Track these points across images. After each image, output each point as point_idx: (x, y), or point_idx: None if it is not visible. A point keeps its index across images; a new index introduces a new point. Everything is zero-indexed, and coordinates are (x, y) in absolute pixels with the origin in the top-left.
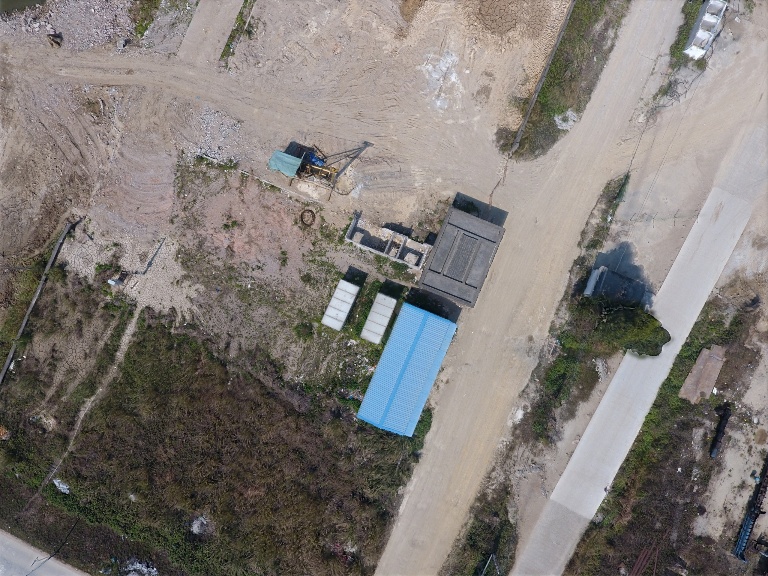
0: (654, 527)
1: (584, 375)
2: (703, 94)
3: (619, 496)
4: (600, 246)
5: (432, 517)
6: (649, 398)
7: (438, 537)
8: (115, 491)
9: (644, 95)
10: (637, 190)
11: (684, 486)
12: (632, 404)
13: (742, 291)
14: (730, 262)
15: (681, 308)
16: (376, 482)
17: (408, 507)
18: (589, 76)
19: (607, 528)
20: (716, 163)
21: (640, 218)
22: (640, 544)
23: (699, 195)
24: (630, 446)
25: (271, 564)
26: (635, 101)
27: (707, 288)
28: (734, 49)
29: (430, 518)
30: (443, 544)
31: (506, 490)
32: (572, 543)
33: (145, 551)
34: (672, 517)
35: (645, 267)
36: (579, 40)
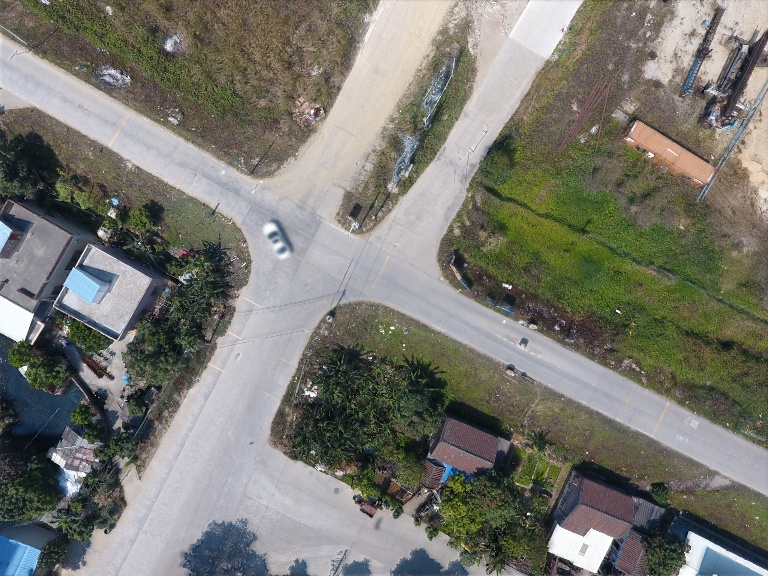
0: (607, 67)
1: None
2: None
3: (575, 36)
4: None
5: (396, 47)
6: None
7: (401, 66)
8: (93, 3)
9: None
10: None
11: (638, 31)
12: None
13: None
14: None
15: None
16: (343, 1)
17: (373, 36)
18: None
19: (562, 69)
20: None
21: None
22: (593, 80)
23: None
24: None
25: (240, 75)
26: None
27: None
28: None
29: (394, 47)
30: (405, 73)
31: (468, 25)
32: (528, 80)
33: (120, 63)
34: (625, 57)
35: None
36: None
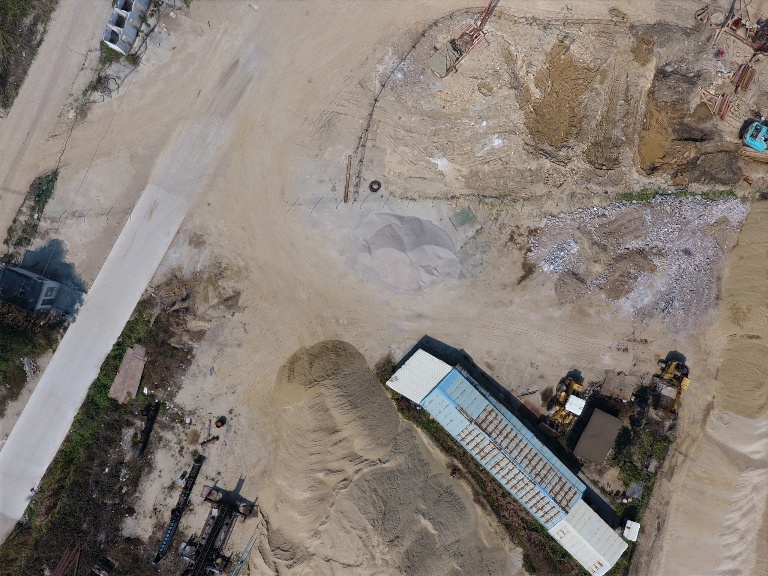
0: (80, 528)
1: (11, 374)
2: (137, 90)
3: None
4: (26, 244)
5: None
6: (79, 398)
7: None
8: None
9: (74, 91)
10: (67, 187)
11: (112, 487)
12: (61, 404)
13: (178, 290)
14: (165, 260)
15: (113, 307)
16: None
17: None
18: (17, 71)
19: (36, 529)
20: (151, 160)
21: (71, 215)
22: (63, 545)
23: (133, 192)
24: (59, 446)
25: None
26: (64, 97)
27: (140, 287)
28: (170, 45)
29: None
30: None
31: None
32: None
33: None
34: (97, 518)
35: (77, 265)
36: (3, 35)
